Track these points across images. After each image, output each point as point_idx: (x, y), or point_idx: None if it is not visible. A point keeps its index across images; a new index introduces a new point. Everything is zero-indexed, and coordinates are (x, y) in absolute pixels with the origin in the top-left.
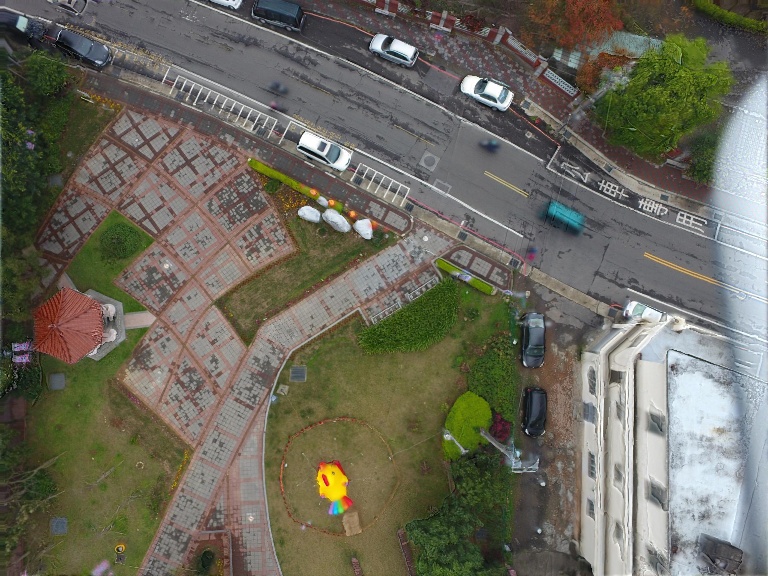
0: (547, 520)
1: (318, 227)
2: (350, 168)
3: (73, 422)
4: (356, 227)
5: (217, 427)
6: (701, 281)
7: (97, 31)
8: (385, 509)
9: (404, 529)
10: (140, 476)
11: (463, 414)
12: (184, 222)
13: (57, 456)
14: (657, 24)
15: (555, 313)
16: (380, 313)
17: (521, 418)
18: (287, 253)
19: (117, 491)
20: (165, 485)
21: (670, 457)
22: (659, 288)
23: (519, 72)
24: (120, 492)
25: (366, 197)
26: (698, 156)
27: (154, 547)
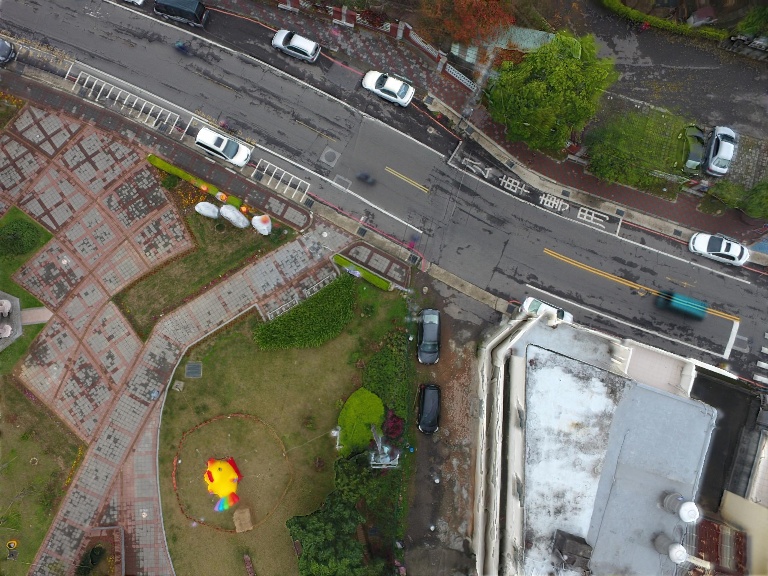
0: (441, 517)
1: (217, 223)
2: (251, 164)
3: None
4: (252, 223)
5: (112, 423)
6: (601, 277)
7: (1, 27)
8: (277, 506)
9: None
10: (34, 472)
11: (355, 410)
12: (83, 218)
13: None
14: (566, 19)
15: (453, 309)
16: (277, 309)
17: (417, 415)
18: (185, 249)
19: (10, 487)
20: (59, 481)
21: (527, 452)
22: (558, 284)
23: (422, 67)
24: (13, 488)
25: (266, 193)
26: (602, 151)
27: (47, 543)
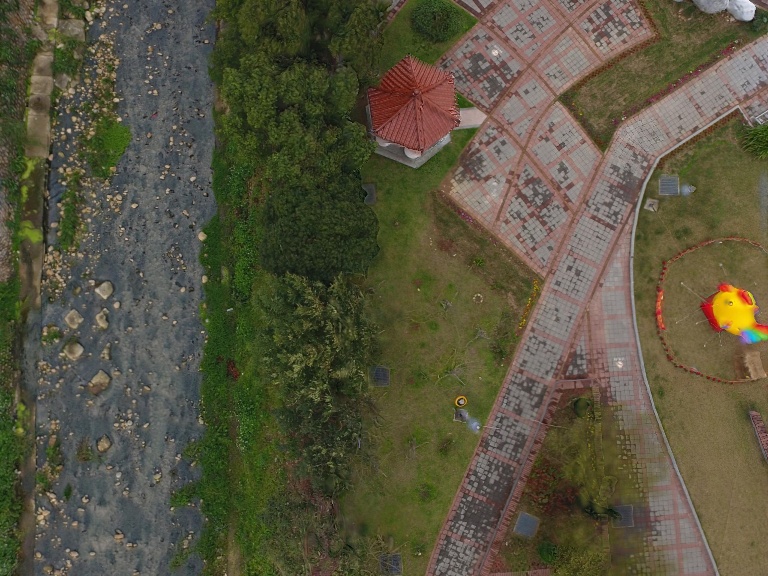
0: None
1: (680, 8)
2: None
3: (390, 244)
4: (738, 2)
5: (572, 251)
6: None
7: None
8: None
9: None
10: (478, 312)
11: None
12: None
13: (378, 284)
14: None
15: None
16: (764, 112)
17: None
18: (644, 39)
19: (451, 330)
20: (511, 323)
21: None
22: None
23: None
24: (455, 332)
25: None
26: None
27: (501, 400)
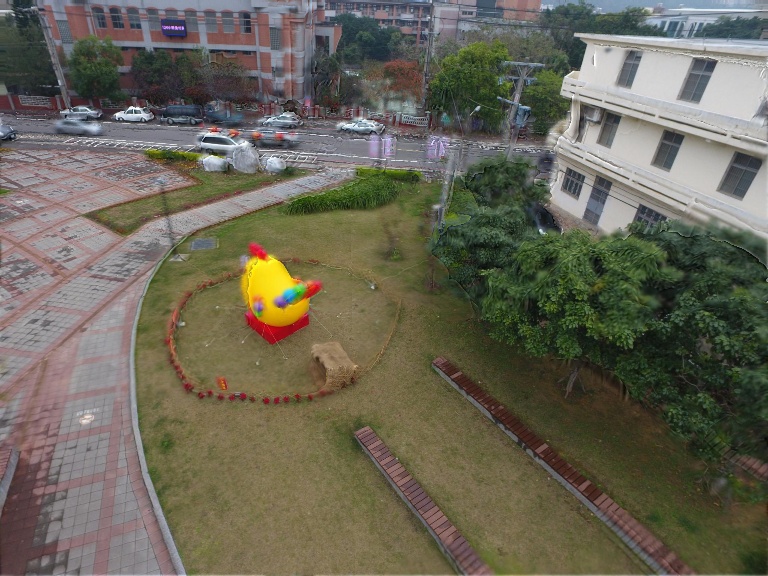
0: None
1: (226, 173)
2: None
3: None
4: None
5: (45, 306)
6: None
7: None
8: (391, 333)
9: (442, 358)
10: None
11: None
12: None
13: None
14: None
15: None
16: None
17: None
18: (190, 185)
19: None
20: None
21: None
22: None
23: None
24: None
25: None
26: None
27: None
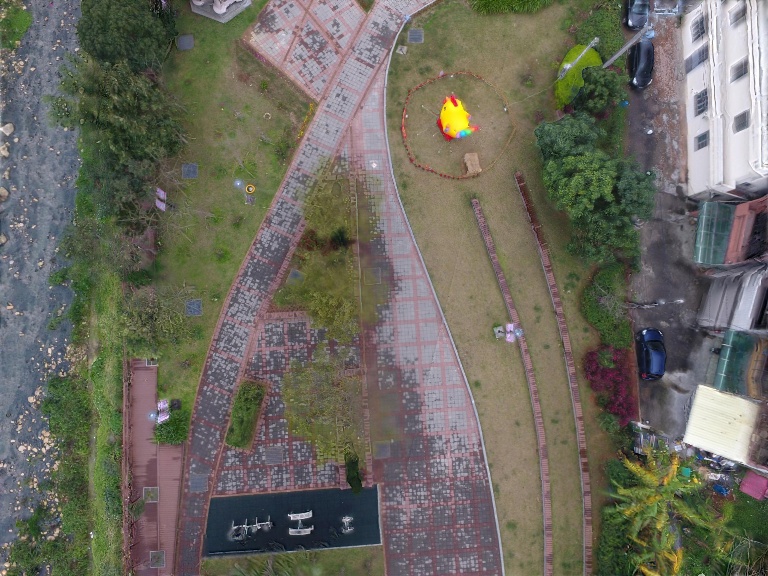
0: (655, 165)
1: None
2: None
3: (203, 77)
4: None
5: (340, 83)
6: None
7: None
8: (503, 152)
9: (521, 172)
10: (267, 126)
11: None
12: None
13: None
14: None
15: None
16: None
17: None
18: None
19: (246, 139)
20: (292, 134)
21: None
22: None
23: None
24: (249, 140)
25: None
26: None
27: (282, 190)
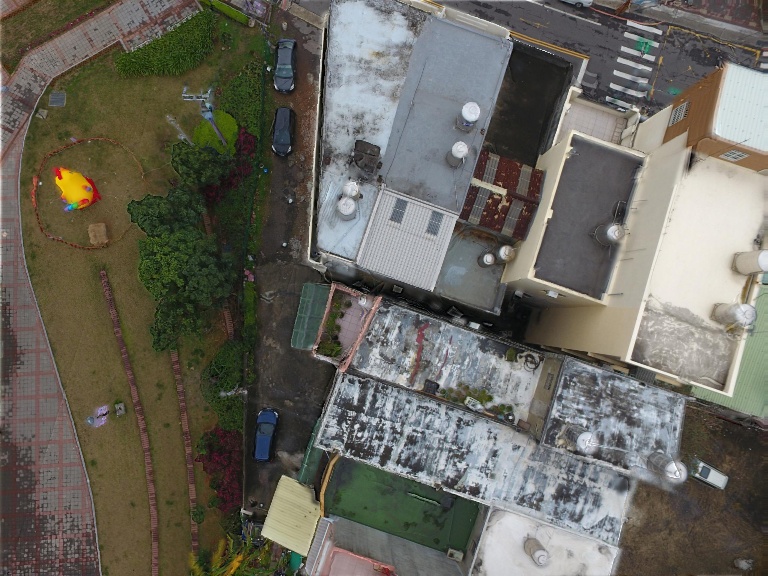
0: (294, 236)
1: None
2: None
3: None
4: None
5: None
6: None
7: None
8: None
9: None
10: None
11: (210, 130)
12: None
13: None
14: None
15: (312, 45)
16: (141, 44)
17: None
18: None
19: None
20: None
21: (327, 77)
22: None
23: None
24: None
25: None
26: None
27: None
